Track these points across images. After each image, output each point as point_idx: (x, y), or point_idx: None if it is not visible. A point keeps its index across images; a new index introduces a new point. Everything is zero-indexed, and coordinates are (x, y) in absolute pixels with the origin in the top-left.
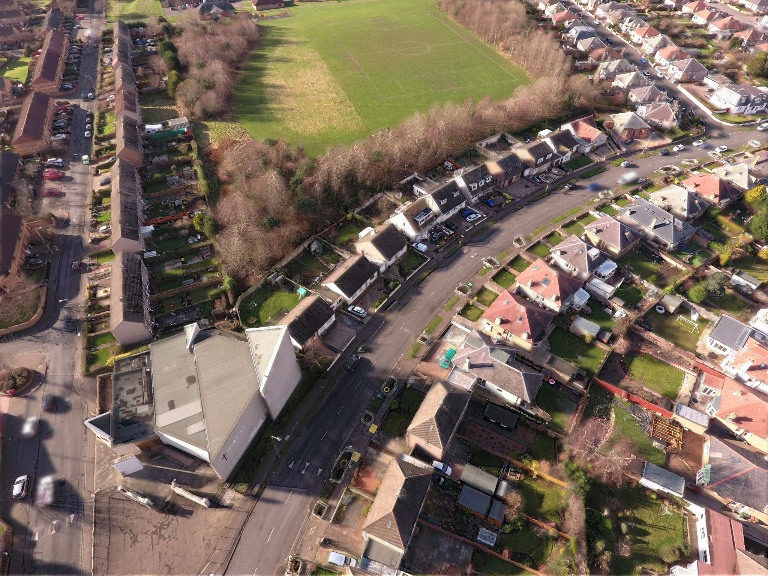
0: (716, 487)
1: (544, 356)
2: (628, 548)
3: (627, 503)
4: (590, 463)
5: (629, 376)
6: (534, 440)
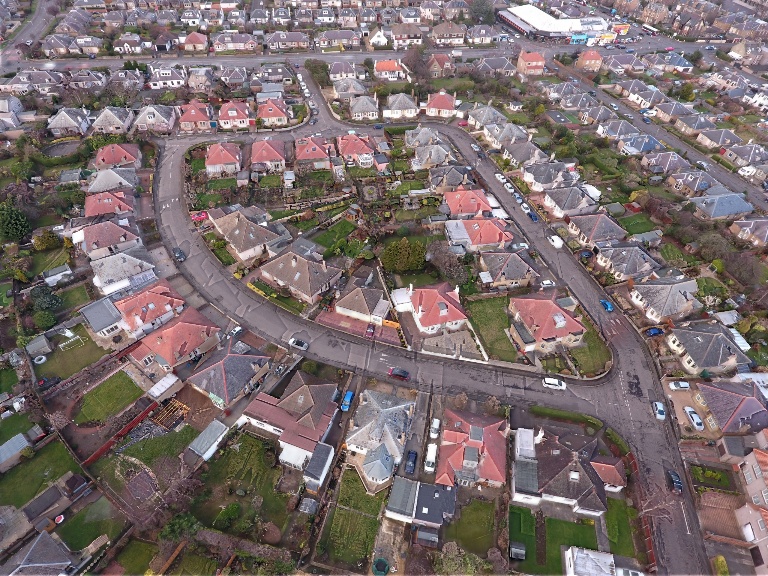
0: (229, 397)
1: (19, 519)
2: (257, 497)
3: (220, 480)
4: (171, 505)
5: (98, 425)
6: (122, 567)
